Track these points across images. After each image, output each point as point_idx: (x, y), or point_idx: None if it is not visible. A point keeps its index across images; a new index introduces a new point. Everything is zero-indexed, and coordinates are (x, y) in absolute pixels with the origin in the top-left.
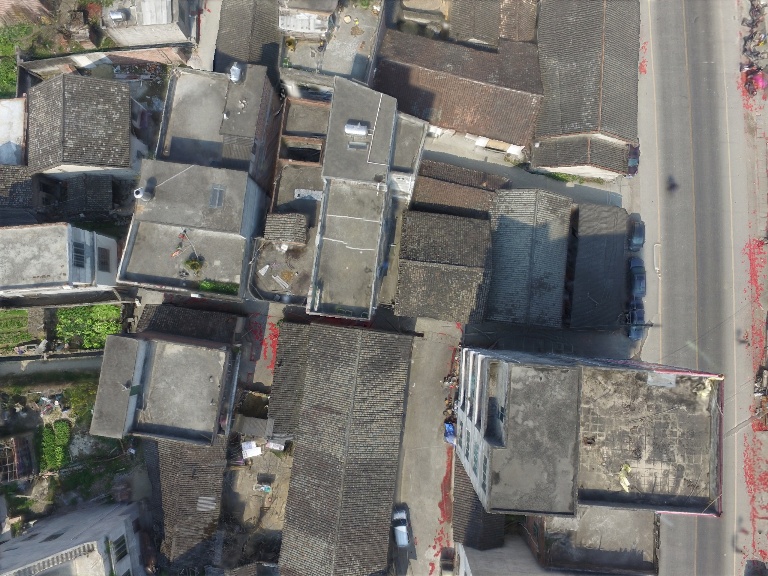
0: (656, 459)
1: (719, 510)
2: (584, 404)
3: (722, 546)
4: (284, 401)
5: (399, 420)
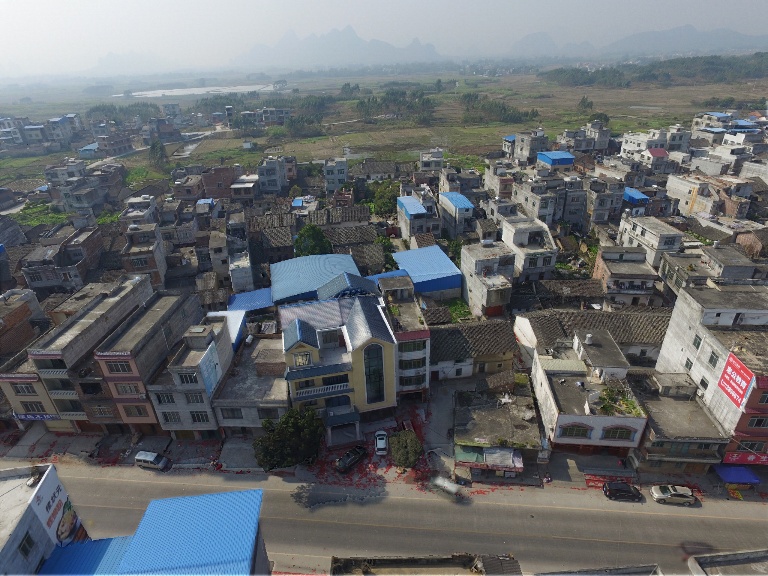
0: (763, 361)
1: (760, 376)
2: (765, 336)
3: (682, 571)
4: (633, 311)
5: (658, 342)
